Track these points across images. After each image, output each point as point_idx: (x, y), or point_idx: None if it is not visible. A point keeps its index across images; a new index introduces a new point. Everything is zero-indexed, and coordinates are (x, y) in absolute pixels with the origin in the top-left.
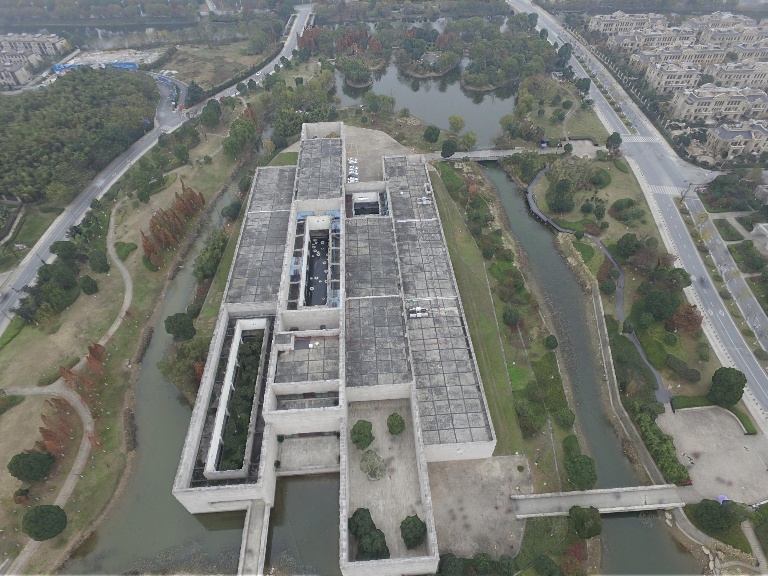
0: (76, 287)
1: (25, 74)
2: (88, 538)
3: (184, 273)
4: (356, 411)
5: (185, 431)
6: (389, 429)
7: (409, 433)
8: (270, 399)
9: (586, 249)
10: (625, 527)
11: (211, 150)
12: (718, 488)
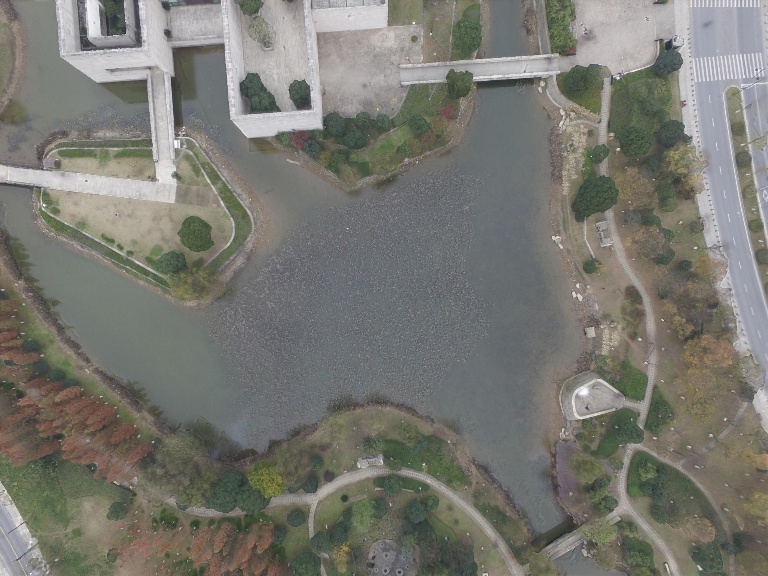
0: None
1: None
2: (8, 104)
3: None
4: None
5: None
6: None
7: None
8: None
9: None
10: (502, 95)
11: None
12: (599, 58)
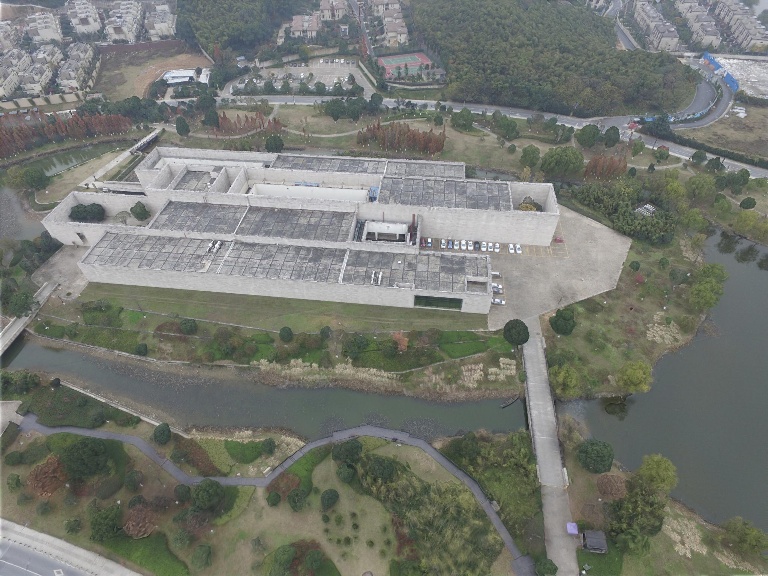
0: (350, 116)
1: (672, 44)
2: None
3: None
4: None
5: None
6: None
7: None
8: (178, 167)
9: (245, 451)
10: None
11: None
12: None
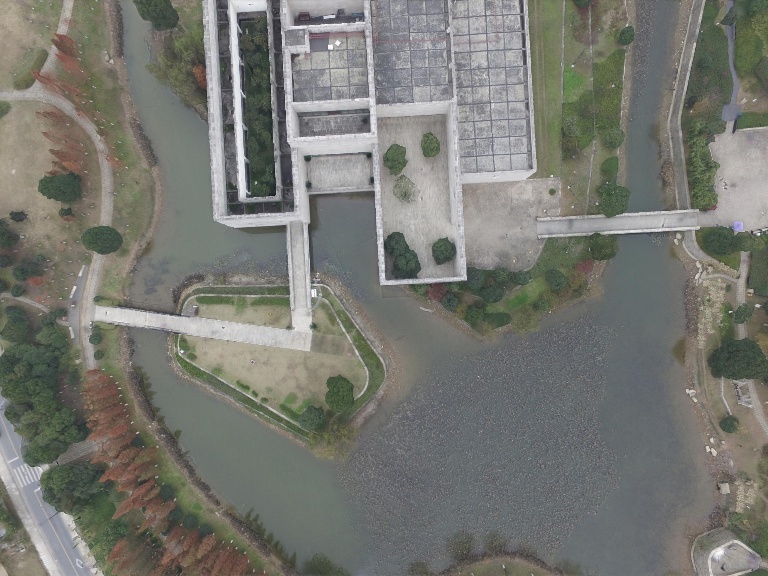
0: None
1: None
2: (146, 247)
3: None
4: (386, 126)
5: (201, 140)
6: (423, 151)
7: (443, 153)
8: (293, 122)
9: None
10: (634, 242)
11: None
12: (738, 213)
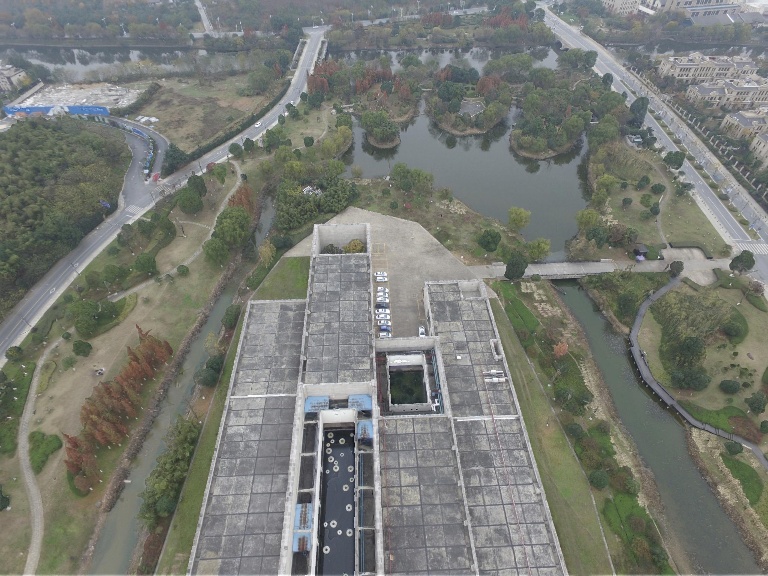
0: None
1: None
2: None
3: (130, 495)
4: None
5: None
6: None
7: None
8: None
9: (748, 475)
10: None
11: (189, 251)
12: None
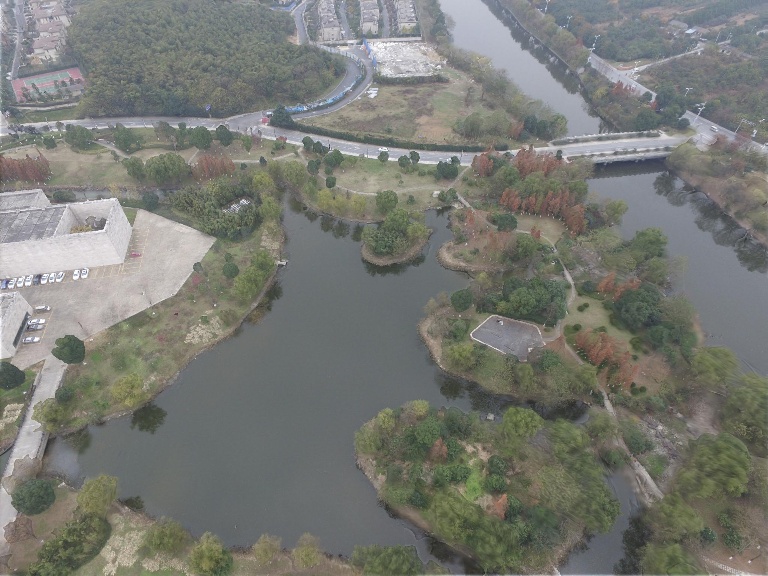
0: None
1: (335, 33)
2: None
3: None
4: None
5: None
6: None
7: None
8: None
9: None
10: None
11: None
12: None
